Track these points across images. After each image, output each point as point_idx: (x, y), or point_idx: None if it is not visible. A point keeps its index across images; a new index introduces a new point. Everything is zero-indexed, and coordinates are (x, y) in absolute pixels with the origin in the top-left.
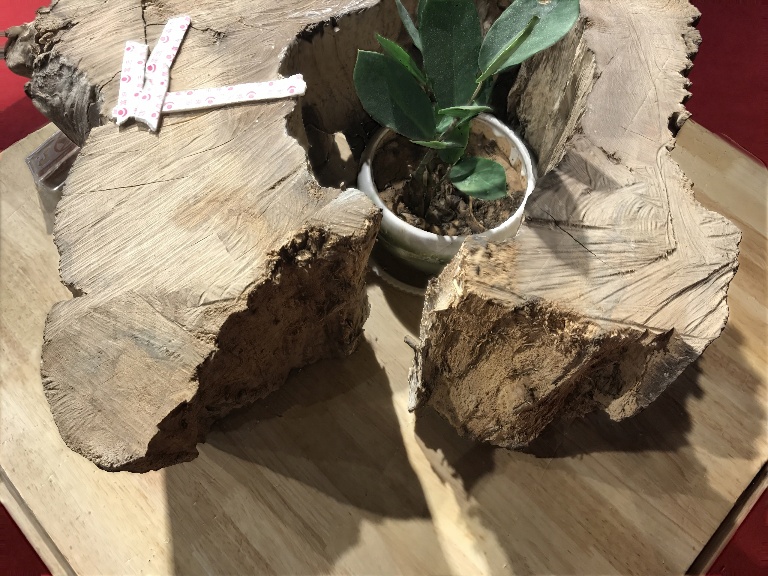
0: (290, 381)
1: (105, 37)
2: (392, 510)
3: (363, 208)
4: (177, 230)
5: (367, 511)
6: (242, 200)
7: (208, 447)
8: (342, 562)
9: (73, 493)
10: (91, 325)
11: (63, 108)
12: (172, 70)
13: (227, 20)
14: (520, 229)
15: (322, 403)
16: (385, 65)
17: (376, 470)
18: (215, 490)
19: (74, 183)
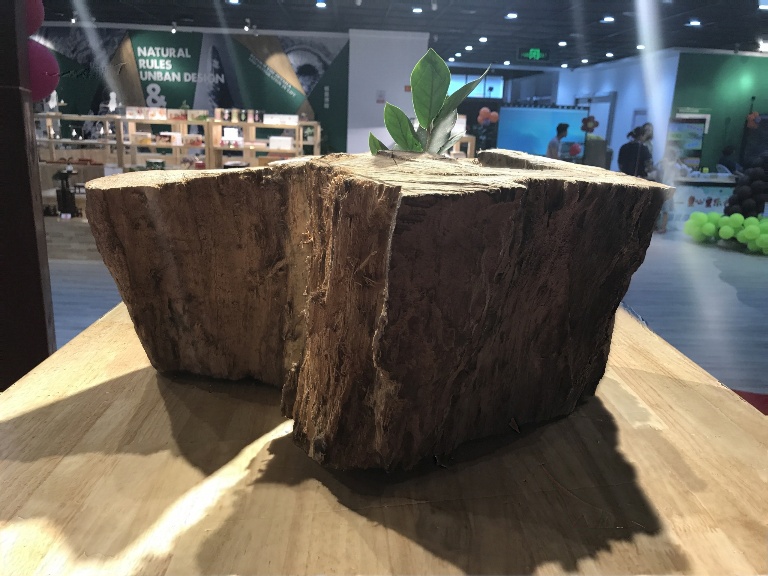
0: (241, 386)
1: None
2: (192, 457)
3: None
4: None
5: (178, 448)
6: None
7: (154, 380)
8: (122, 455)
9: (73, 360)
10: None
11: None
12: None
13: None
14: None
15: (241, 400)
16: None
17: (218, 438)
18: (126, 394)
19: None
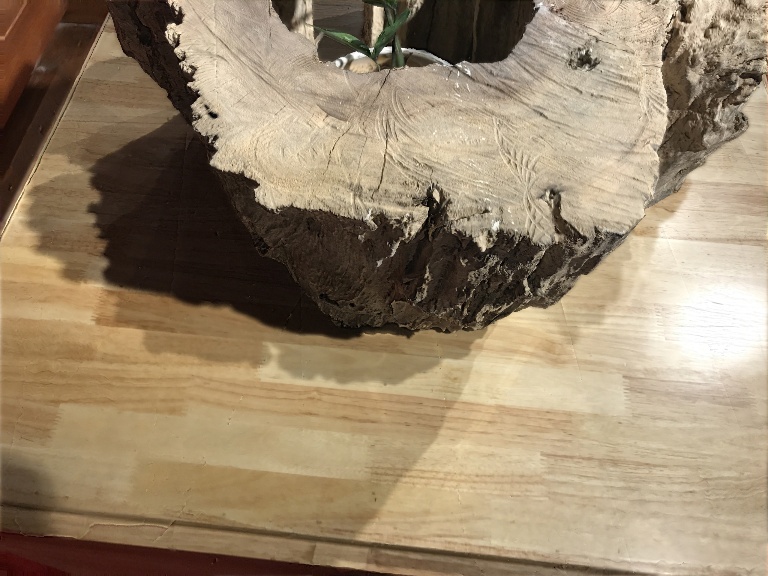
0: None
1: None
2: None
3: None
4: None
5: None
6: None
7: None
8: None
9: None
10: None
11: None
12: None
13: None
14: None
15: None
16: None
17: None
18: None
19: None
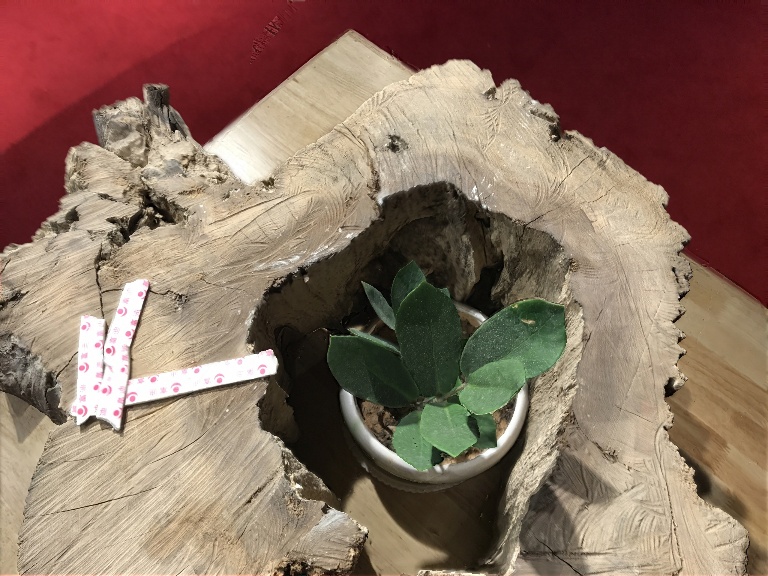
0: None
1: (58, 309)
2: None
3: (347, 535)
4: (150, 562)
5: None
6: (217, 520)
7: None
8: None
9: None
10: None
11: (19, 387)
12: (133, 348)
13: (188, 279)
14: (516, 564)
15: None
16: (360, 346)
17: None
18: None
19: (36, 502)
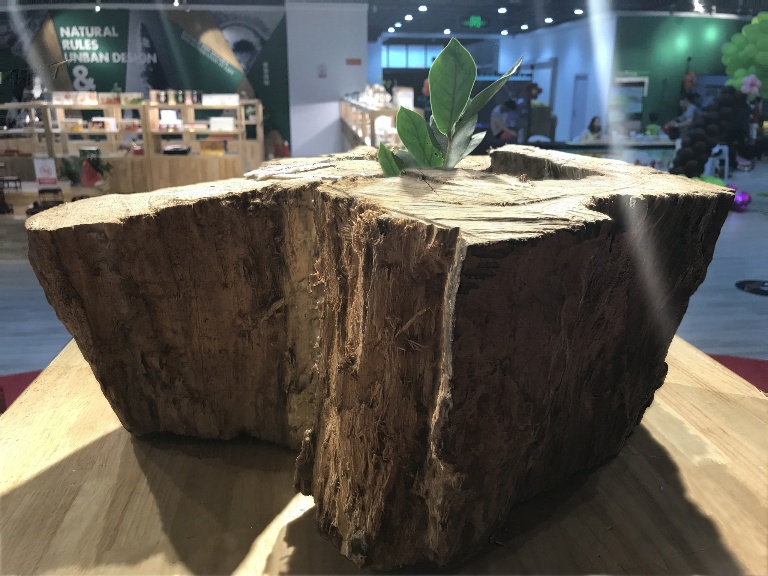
0: (235, 445)
1: None
2: (193, 561)
3: (312, 180)
4: None
5: (173, 549)
6: None
7: (130, 447)
8: (103, 569)
9: (27, 426)
10: (114, 198)
11: None
12: None
13: None
14: None
15: (240, 467)
16: (412, 160)
17: (220, 528)
18: (97, 471)
19: None
